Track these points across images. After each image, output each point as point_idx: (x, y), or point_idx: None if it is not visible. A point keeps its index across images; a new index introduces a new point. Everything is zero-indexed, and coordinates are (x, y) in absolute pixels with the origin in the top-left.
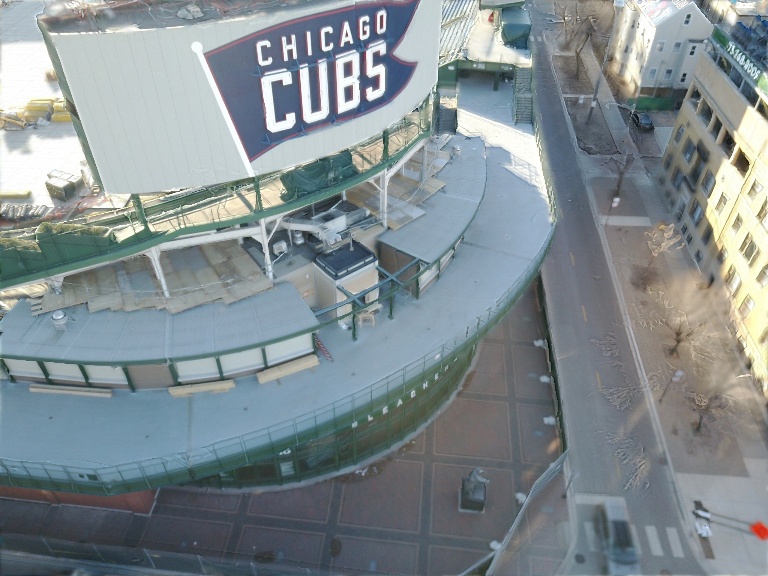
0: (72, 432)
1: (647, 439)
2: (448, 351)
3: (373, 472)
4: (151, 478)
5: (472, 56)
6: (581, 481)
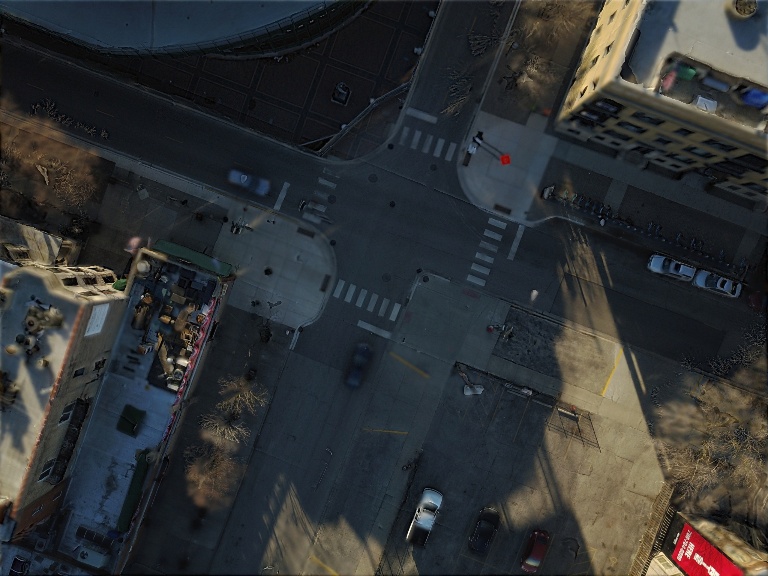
0: (81, 10)
1: (478, 82)
2: (333, 1)
3: (285, 61)
4: (131, 56)
5: None
6: (416, 100)
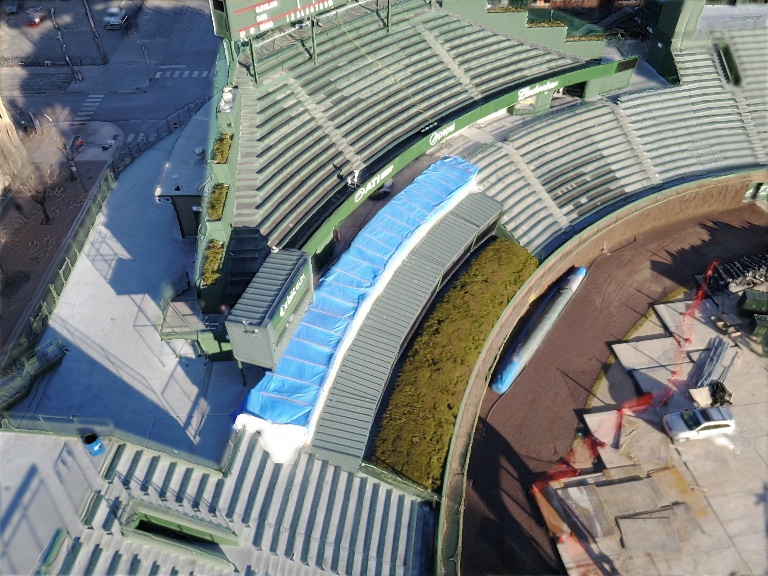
0: None
1: None
2: None
3: None
4: None
5: (69, 473)
6: None
